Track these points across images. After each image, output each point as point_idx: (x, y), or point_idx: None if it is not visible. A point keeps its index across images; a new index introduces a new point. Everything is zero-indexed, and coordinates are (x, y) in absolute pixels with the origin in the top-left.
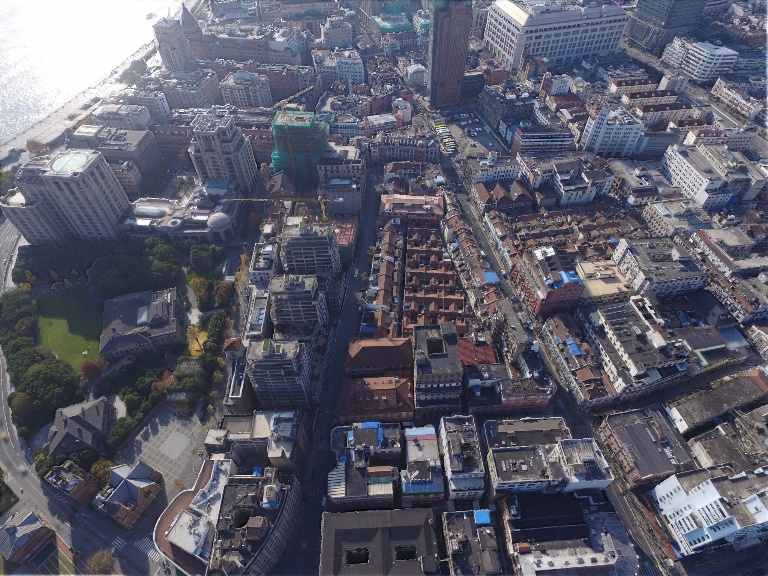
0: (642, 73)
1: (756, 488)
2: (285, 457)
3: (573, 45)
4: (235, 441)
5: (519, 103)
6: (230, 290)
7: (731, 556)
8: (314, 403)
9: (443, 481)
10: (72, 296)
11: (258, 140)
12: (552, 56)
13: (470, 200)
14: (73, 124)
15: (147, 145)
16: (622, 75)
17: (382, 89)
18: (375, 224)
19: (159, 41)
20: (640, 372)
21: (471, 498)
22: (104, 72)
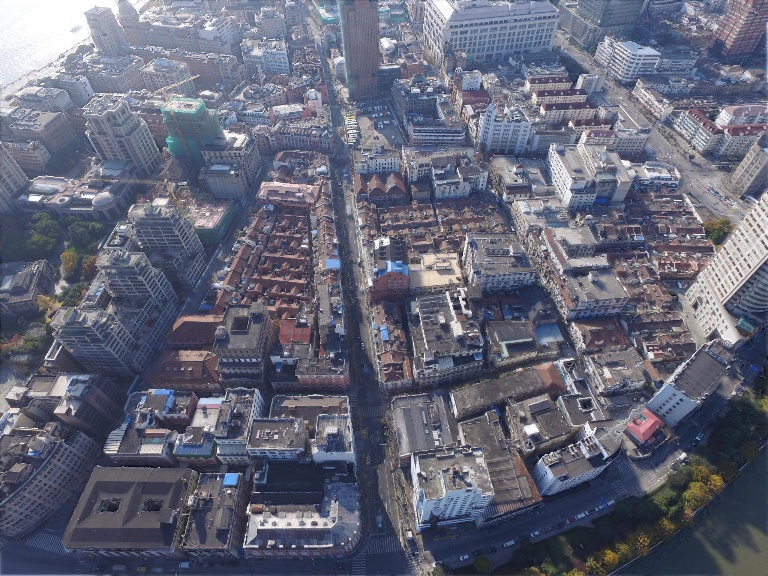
0: (562, 71)
1: None
2: (71, 414)
3: (502, 41)
4: (35, 398)
5: (423, 97)
6: None
7: (471, 533)
8: (137, 371)
9: (213, 446)
10: None
11: (164, 125)
12: (481, 52)
13: None
14: (8, 104)
15: (58, 126)
16: (541, 73)
17: (298, 80)
18: (248, 209)
19: (91, 27)
20: (429, 358)
21: (244, 464)
22: (51, 56)
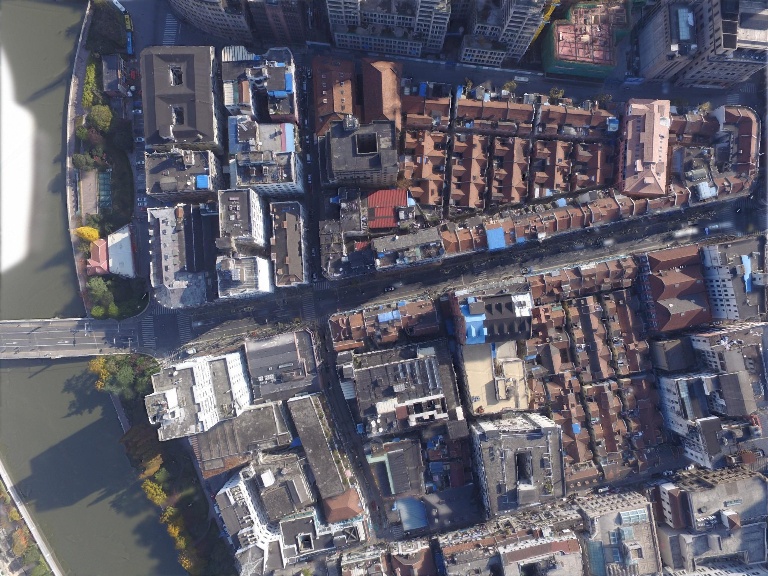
0: None
1: (183, 405)
2: None
3: None
4: None
5: None
6: None
7: None
8: None
9: None
10: None
11: None
12: None
13: (674, 245)
14: None
15: None
16: None
17: None
18: None
19: None
20: None
21: None
22: None
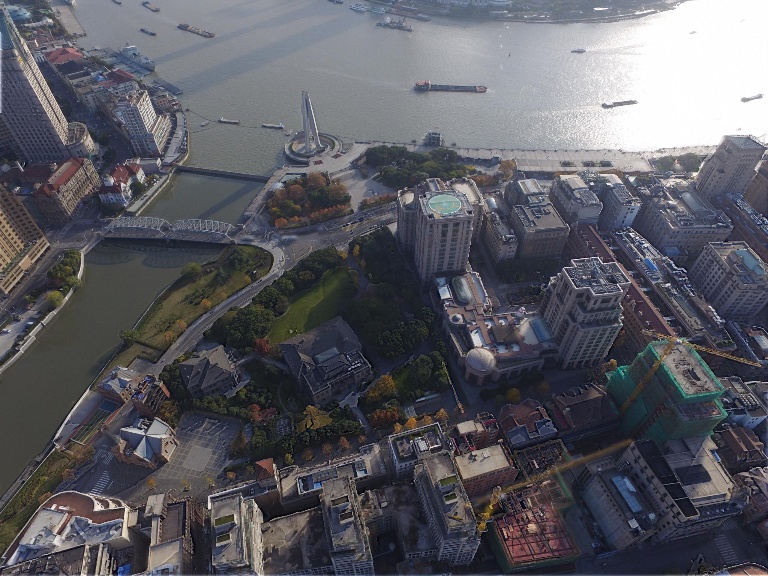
0: None
1: None
2: None
3: None
4: None
5: None
6: (390, 421)
7: None
8: None
9: None
10: (341, 289)
11: None
12: None
13: None
14: (558, 170)
15: (550, 237)
16: None
17: None
18: None
19: (715, 155)
20: None
21: None
22: (652, 145)
